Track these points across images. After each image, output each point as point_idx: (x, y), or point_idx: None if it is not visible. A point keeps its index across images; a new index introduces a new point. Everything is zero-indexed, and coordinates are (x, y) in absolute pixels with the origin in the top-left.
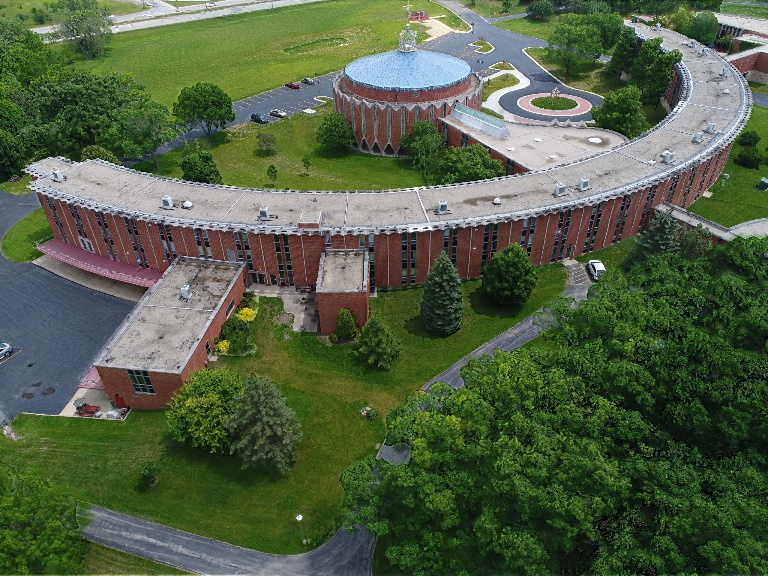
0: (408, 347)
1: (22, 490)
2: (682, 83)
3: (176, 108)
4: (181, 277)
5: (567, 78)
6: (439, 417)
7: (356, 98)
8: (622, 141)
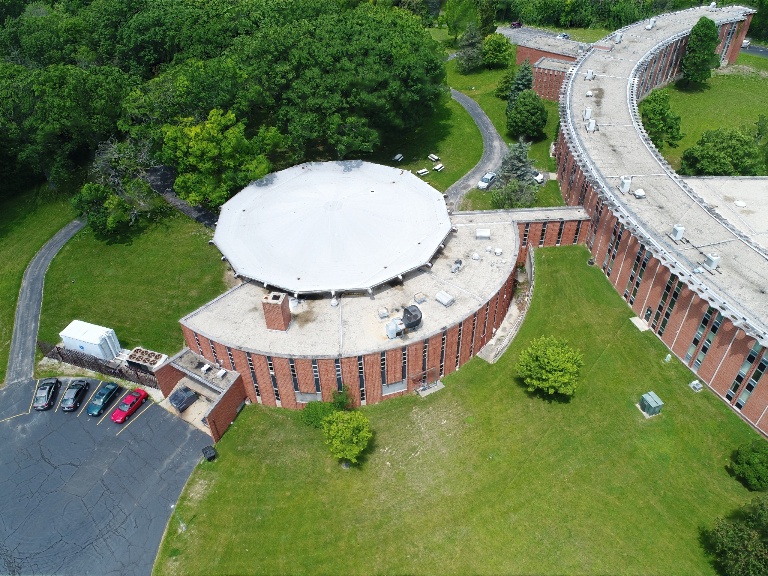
0: (507, 104)
1: (459, 1)
2: None
3: None
4: None
5: None
6: None
7: None
8: None
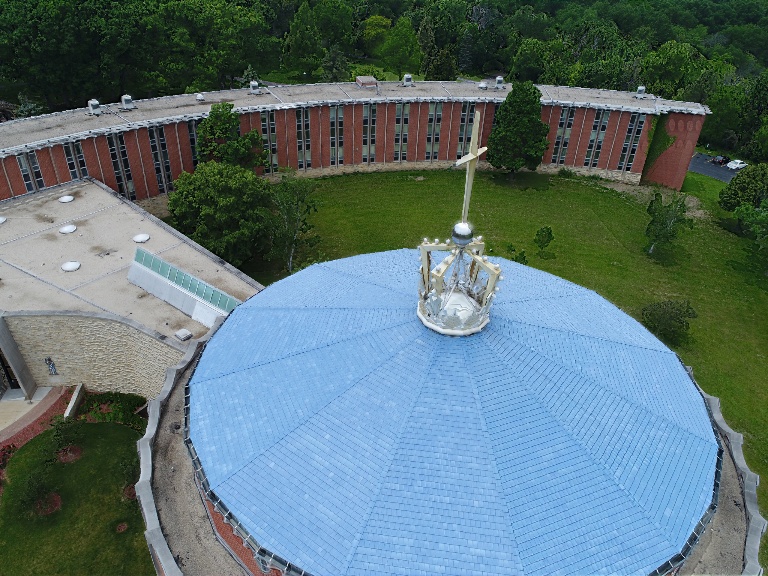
0: None
1: None
2: None
3: None
4: None
5: None
6: (245, 13)
7: None
8: None
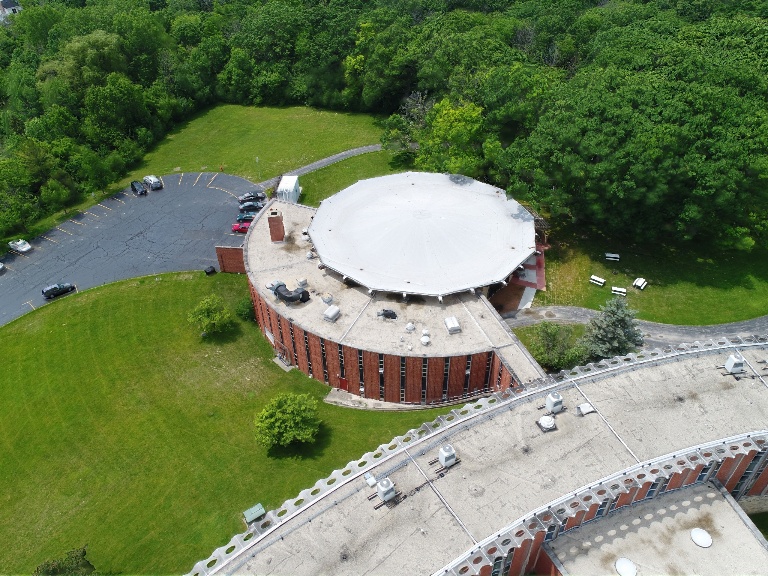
0: None
1: None
2: None
3: None
4: None
5: None
6: None
7: None
8: None
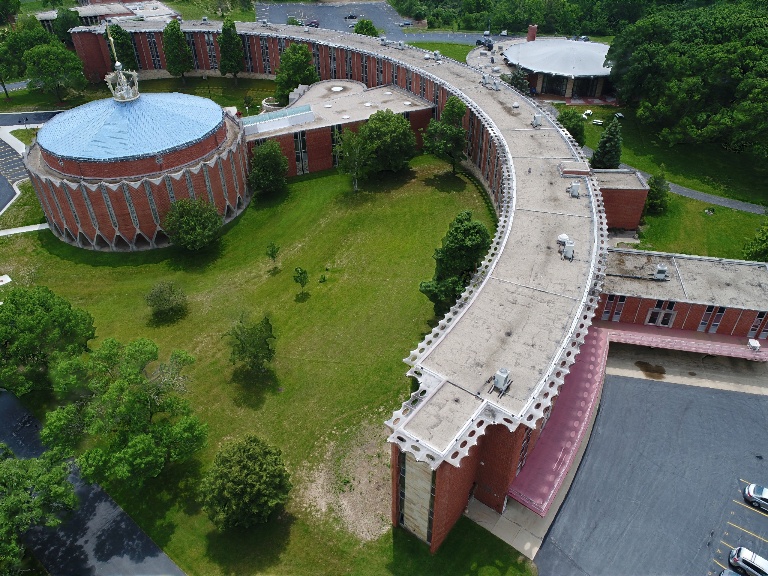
0: None
1: None
2: (247, 44)
3: (30, 370)
4: (627, 286)
5: (74, 105)
6: None
7: (176, 171)
8: (342, 82)
